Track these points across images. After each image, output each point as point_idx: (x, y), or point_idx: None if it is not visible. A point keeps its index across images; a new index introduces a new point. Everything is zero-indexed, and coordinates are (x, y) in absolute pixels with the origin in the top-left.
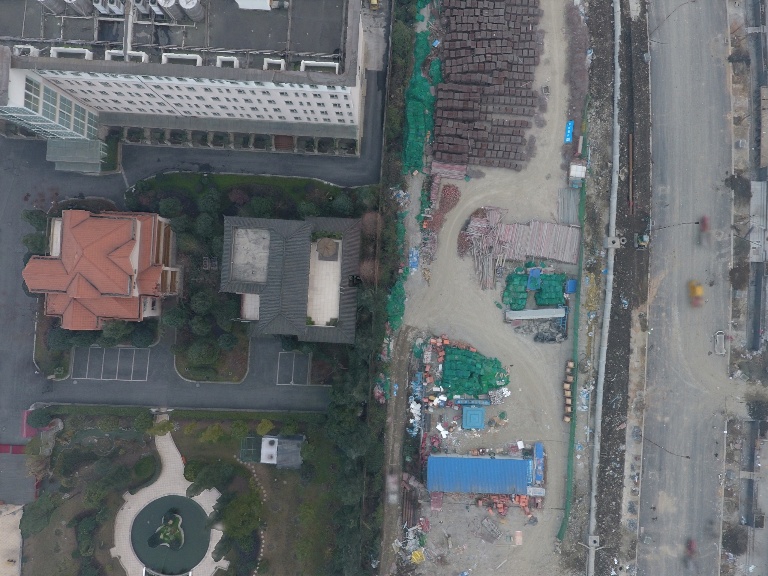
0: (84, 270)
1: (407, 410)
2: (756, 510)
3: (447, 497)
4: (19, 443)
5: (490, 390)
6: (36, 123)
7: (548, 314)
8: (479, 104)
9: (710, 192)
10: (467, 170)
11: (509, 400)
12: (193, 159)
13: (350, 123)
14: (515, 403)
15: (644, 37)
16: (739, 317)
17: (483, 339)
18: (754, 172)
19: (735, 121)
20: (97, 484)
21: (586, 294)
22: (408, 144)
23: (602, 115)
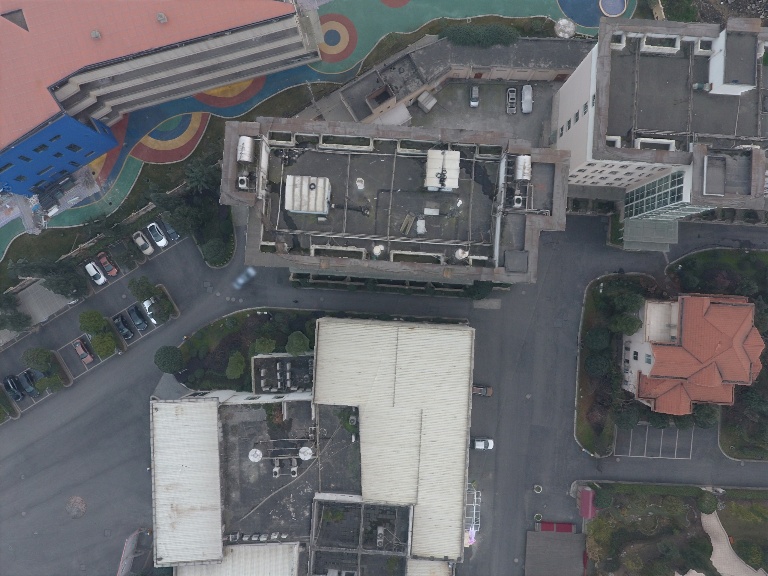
0: (722, 359)
1: None
2: None
3: None
4: (561, 521)
5: None
6: None
7: None
8: None
9: None
10: None
11: None
12: (734, 235)
13: None
14: None
15: None
16: None
17: None
18: None
19: None
20: (666, 567)
21: None
22: None
23: None
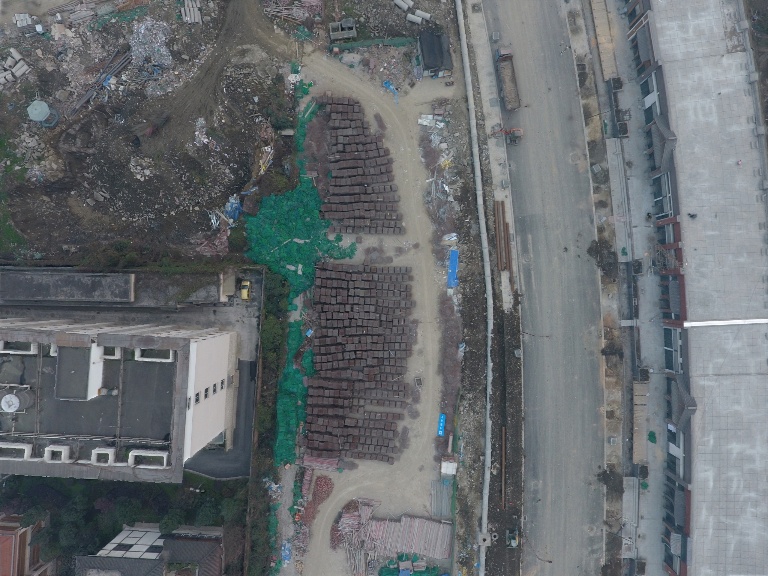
0: None
1: None
2: None
3: None
4: None
5: None
6: None
7: None
8: (351, 397)
9: (582, 487)
10: (338, 465)
11: None
12: None
13: None
14: None
15: (516, 332)
16: None
17: None
18: (628, 463)
19: (608, 415)
20: None
21: None
22: (278, 443)
23: (475, 407)
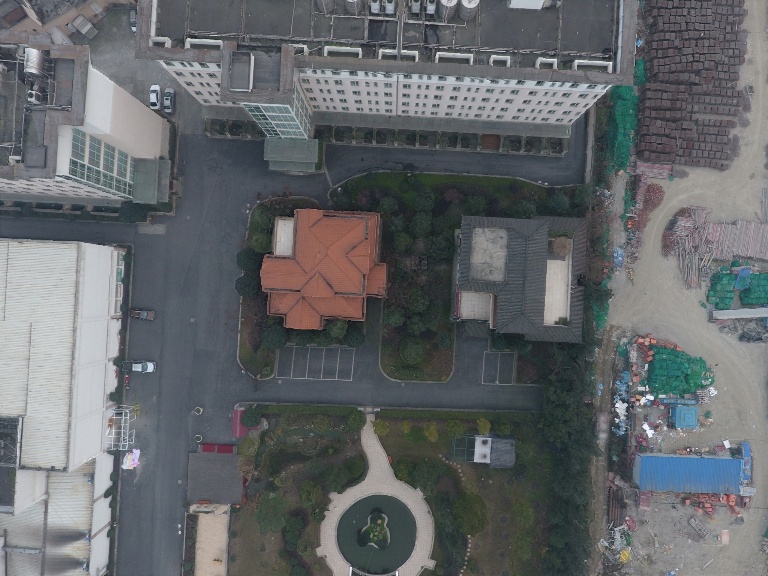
0: (324, 269)
1: (612, 409)
2: None
3: (653, 496)
4: (224, 442)
5: (697, 389)
6: (278, 122)
7: (757, 313)
8: None
9: None
10: (674, 170)
11: (714, 399)
12: (397, 158)
13: (566, 123)
14: (720, 402)
15: None
16: None
17: (688, 338)
18: None
19: None
20: (312, 483)
21: None
22: (617, 144)
23: None
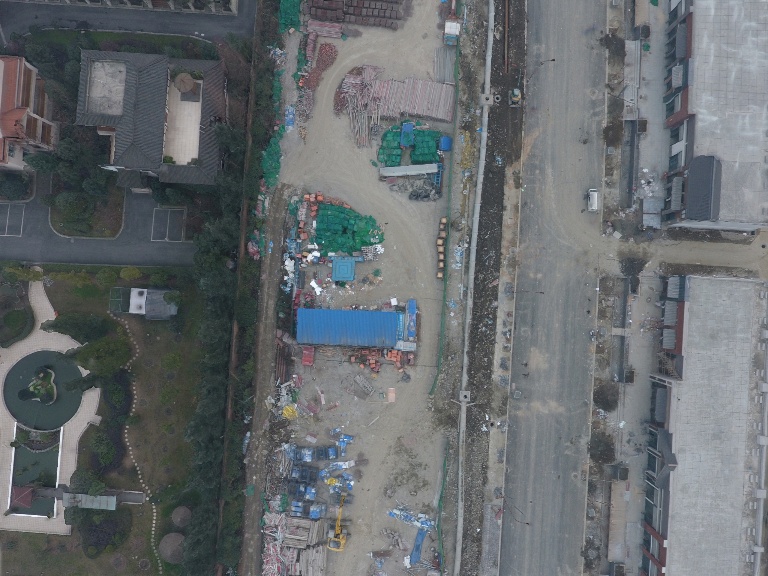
0: None
1: (281, 267)
2: (627, 366)
3: (320, 354)
4: None
5: (363, 246)
6: None
7: (421, 170)
8: None
9: (585, 51)
10: (342, 27)
11: (384, 258)
12: (71, 16)
13: None
14: (389, 261)
15: None
16: (612, 175)
17: (358, 197)
18: (630, 33)
19: None
20: None
21: (461, 152)
22: None
23: None
